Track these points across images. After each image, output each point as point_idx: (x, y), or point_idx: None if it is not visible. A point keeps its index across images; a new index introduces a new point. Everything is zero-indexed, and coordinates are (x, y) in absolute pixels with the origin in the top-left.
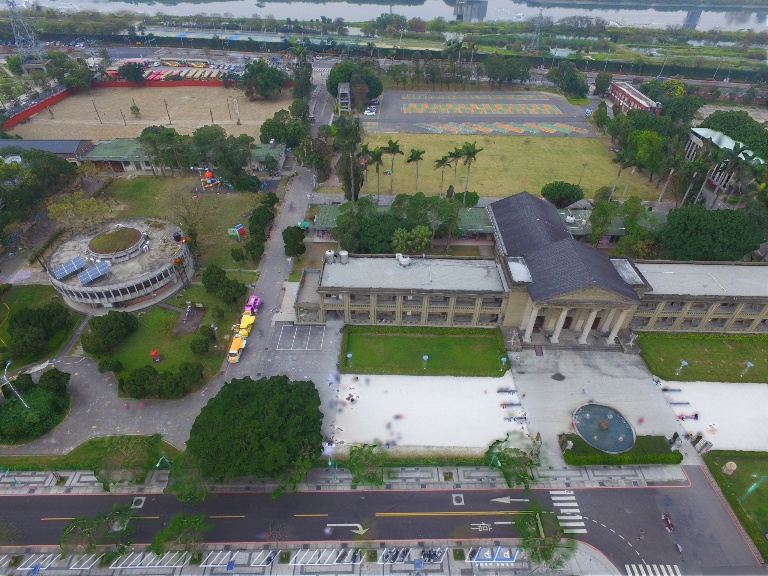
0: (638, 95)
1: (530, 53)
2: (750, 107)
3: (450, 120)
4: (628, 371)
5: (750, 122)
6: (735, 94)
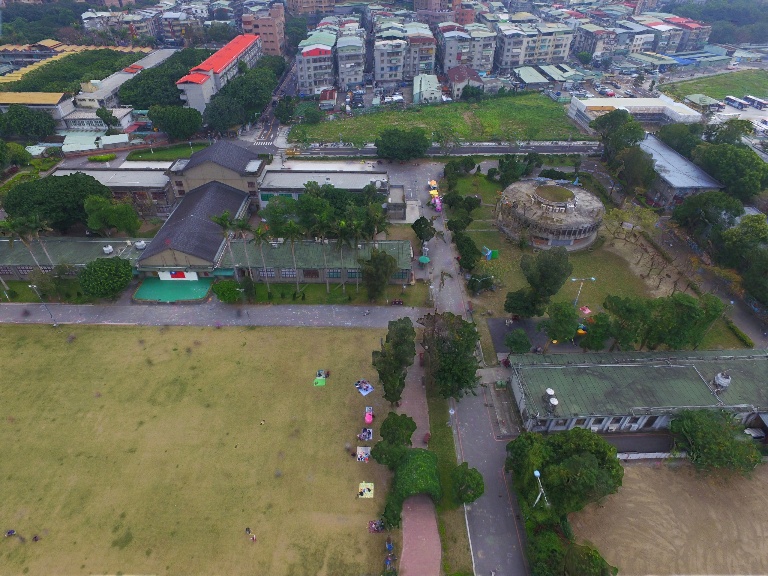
0: None
1: None
2: None
3: None
4: None
5: None
6: None
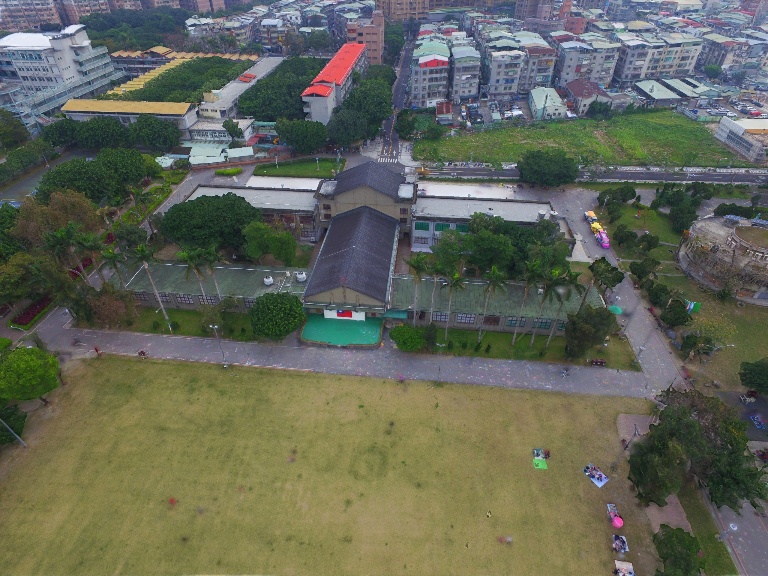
0: None
1: None
2: None
3: None
4: None
5: None
6: None
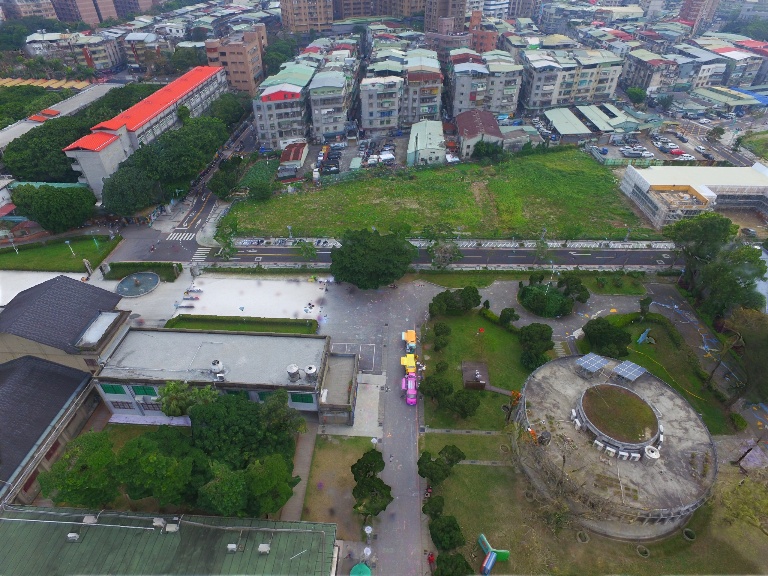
0: None
1: None
2: None
3: None
4: None
5: None
6: None
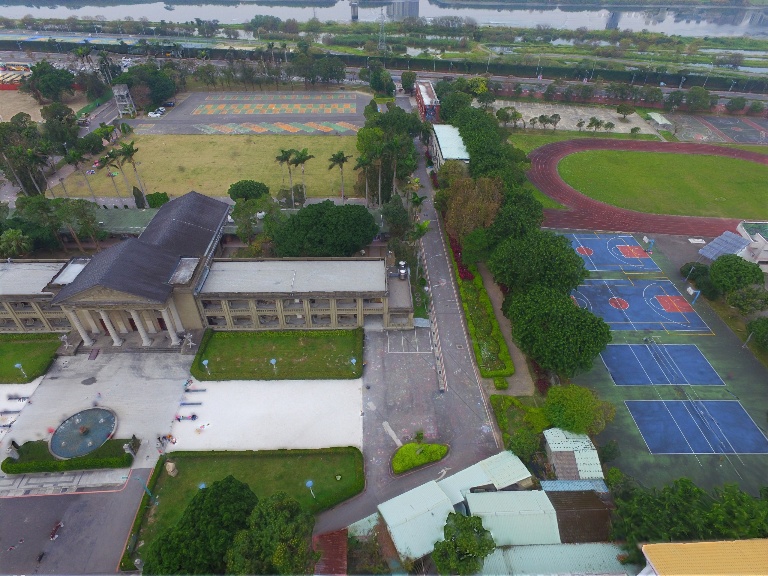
0: (431, 93)
1: (378, 53)
2: (550, 103)
3: (232, 121)
4: (170, 372)
5: (479, 118)
6: (534, 91)
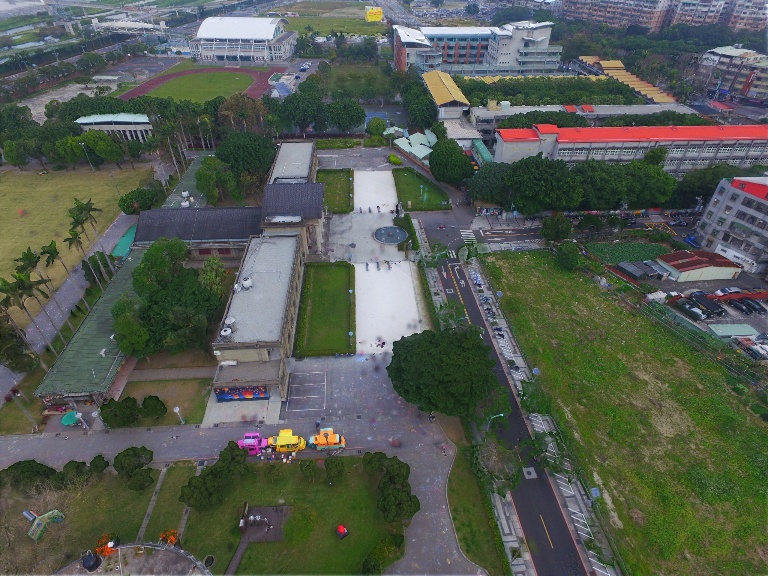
0: None
1: None
2: (17, 102)
3: None
4: (346, 221)
5: (102, 98)
6: None
